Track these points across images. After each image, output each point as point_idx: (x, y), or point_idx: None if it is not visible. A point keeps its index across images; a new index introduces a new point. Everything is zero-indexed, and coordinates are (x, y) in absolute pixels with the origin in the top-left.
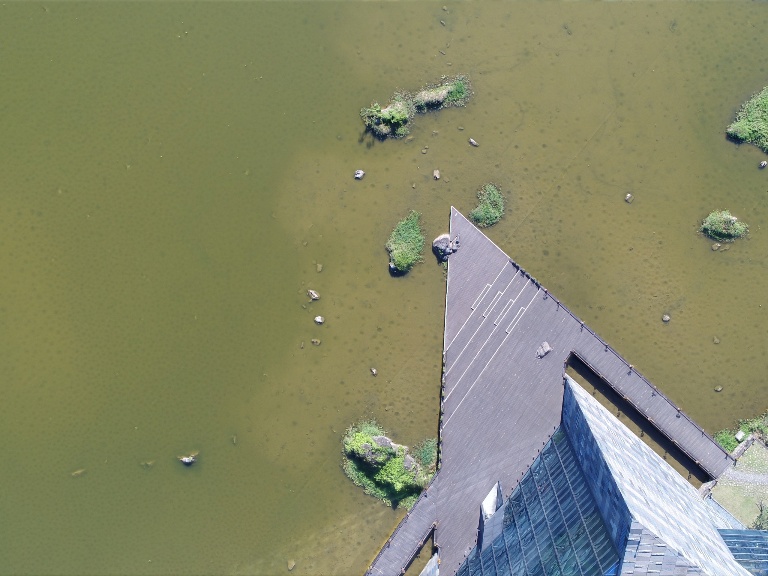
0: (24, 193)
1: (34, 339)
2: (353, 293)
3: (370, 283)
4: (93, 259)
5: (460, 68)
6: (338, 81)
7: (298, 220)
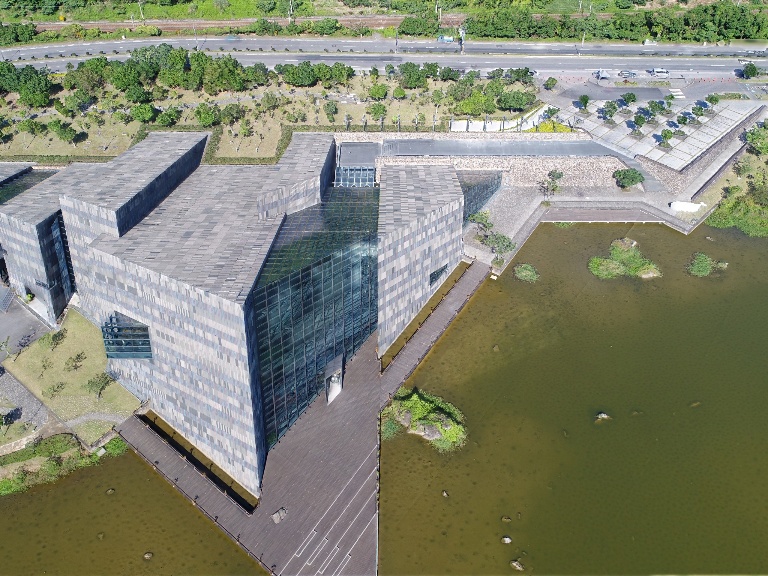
0: None
1: None
2: (477, 569)
3: None
4: None
5: None
6: None
7: None
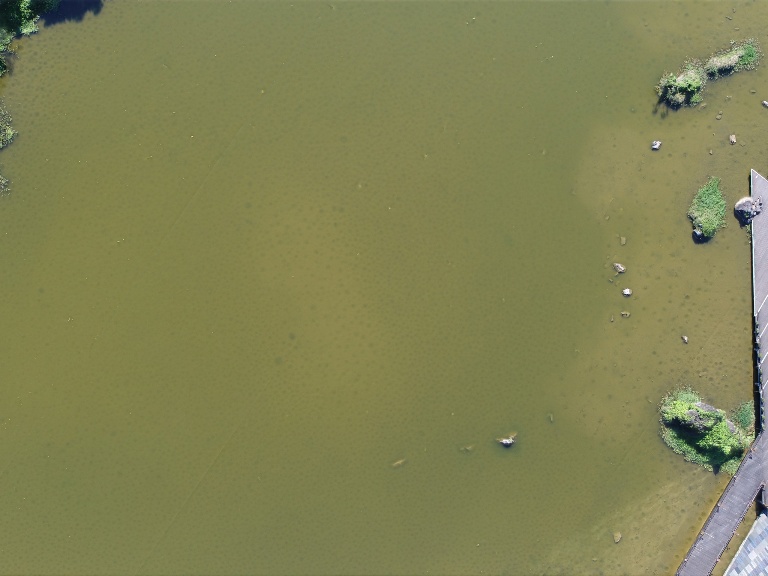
0: (324, 190)
1: (345, 334)
2: (658, 263)
3: (675, 252)
4: (398, 250)
5: (748, 32)
6: (627, 55)
7: (598, 195)
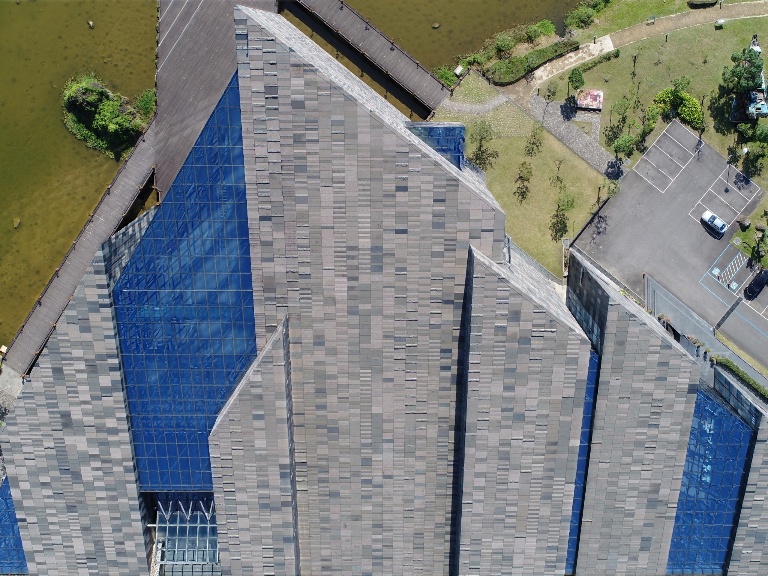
0: None
1: None
2: None
3: None
4: None
5: None
6: None
7: None
